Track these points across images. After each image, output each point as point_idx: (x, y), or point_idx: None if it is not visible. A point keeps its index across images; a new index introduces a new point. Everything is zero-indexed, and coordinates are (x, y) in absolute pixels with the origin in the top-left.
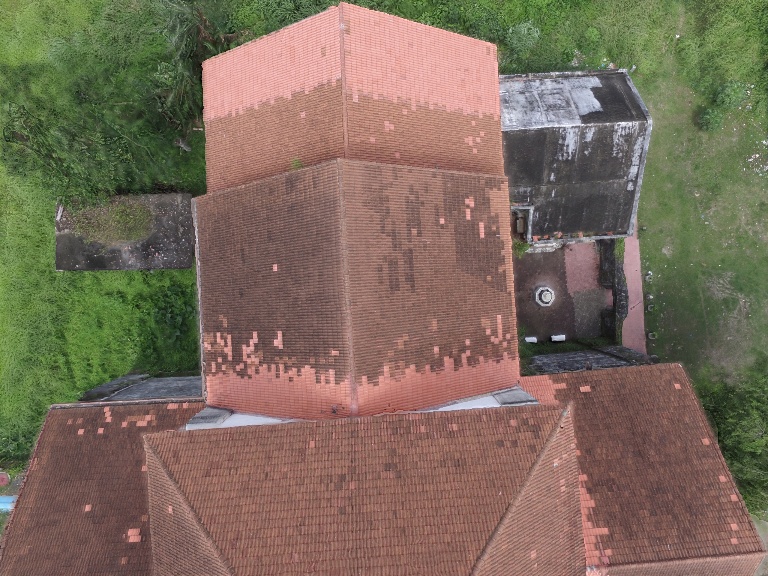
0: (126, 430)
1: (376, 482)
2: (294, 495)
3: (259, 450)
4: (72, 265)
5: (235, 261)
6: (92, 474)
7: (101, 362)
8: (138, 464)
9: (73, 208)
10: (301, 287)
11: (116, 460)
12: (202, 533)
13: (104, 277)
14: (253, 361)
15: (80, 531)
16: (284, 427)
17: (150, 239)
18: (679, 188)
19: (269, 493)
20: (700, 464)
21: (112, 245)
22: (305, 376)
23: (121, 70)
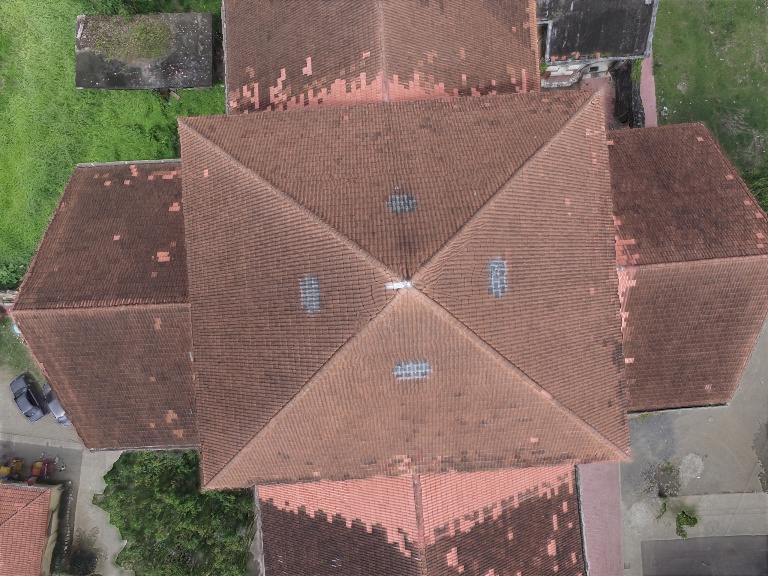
0: (152, 181)
1: (411, 135)
2: (330, 144)
3: (293, 122)
4: (92, 83)
5: (263, 6)
6: (119, 213)
7: None
8: (165, 206)
9: (93, 25)
10: (331, 3)
11: (143, 203)
12: (240, 166)
13: (122, 110)
14: (281, 99)
15: (109, 254)
16: (317, 110)
17: (170, 58)
18: (694, 25)
19: (305, 144)
20: (724, 193)
21: (132, 63)
22: (335, 90)
23: None
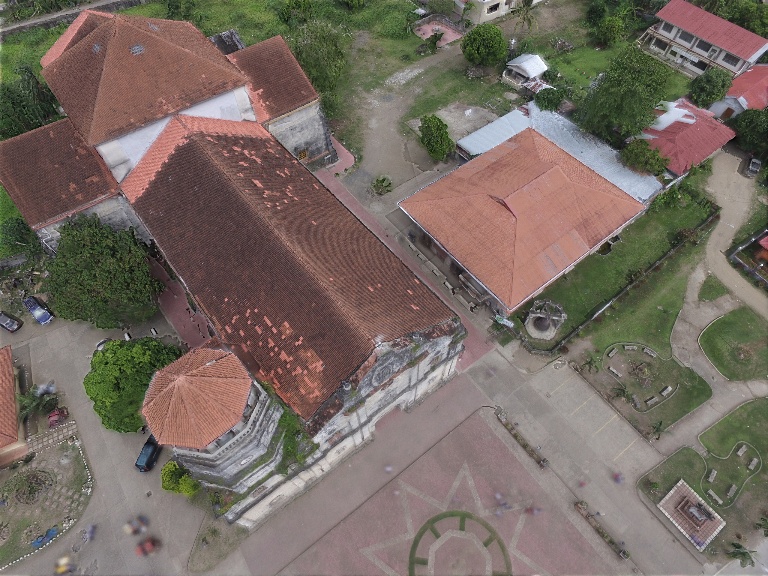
0: None
1: None
2: None
3: None
4: None
5: None
6: None
7: (19, 216)
8: None
9: None
10: None
11: None
12: None
13: None
14: None
15: None
16: None
17: None
18: None
19: None
20: None
21: None
22: None
23: (1, 121)
